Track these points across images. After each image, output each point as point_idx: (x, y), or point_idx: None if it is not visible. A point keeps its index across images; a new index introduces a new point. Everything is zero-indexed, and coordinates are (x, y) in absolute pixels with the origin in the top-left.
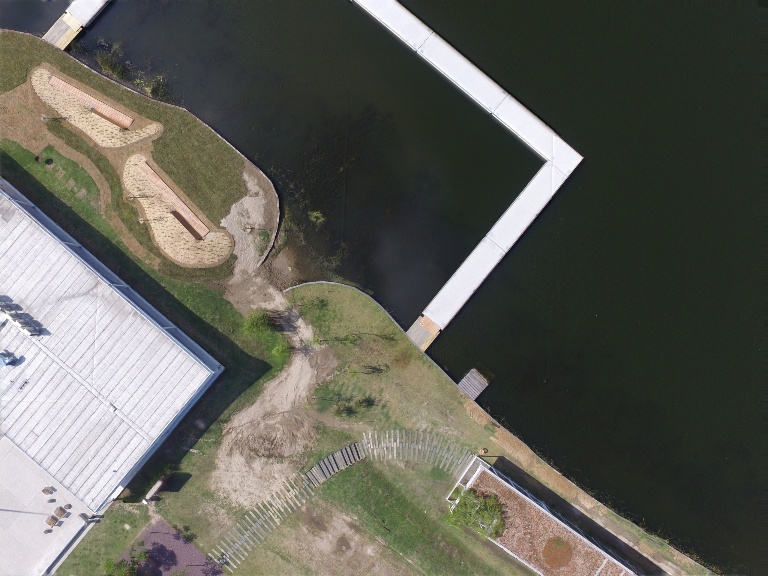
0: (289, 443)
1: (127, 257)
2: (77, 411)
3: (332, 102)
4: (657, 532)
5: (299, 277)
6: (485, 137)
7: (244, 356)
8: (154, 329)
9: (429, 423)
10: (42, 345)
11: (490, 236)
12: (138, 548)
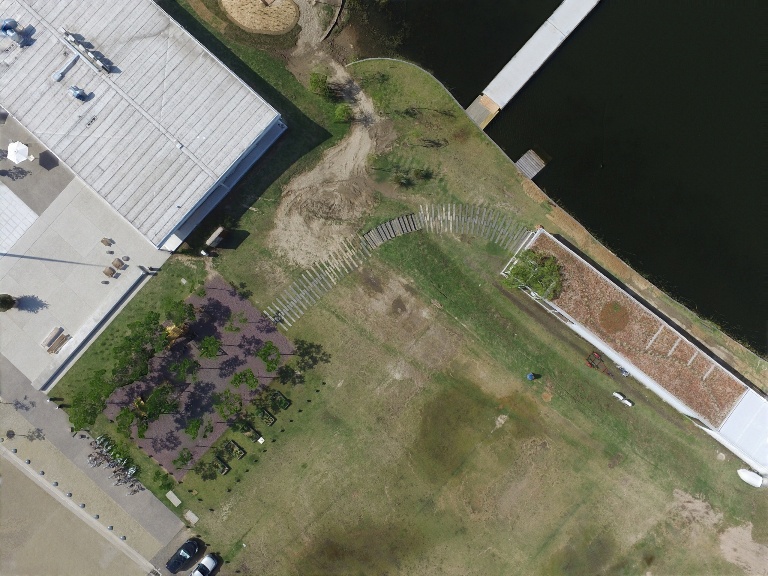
0: (347, 209)
1: (194, 19)
2: (144, 148)
3: None
4: (710, 318)
5: (360, 55)
6: None
7: (306, 119)
8: (223, 70)
9: (486, 198)
10: (112, 82)
11: (551, 20)
12: (194, 303)
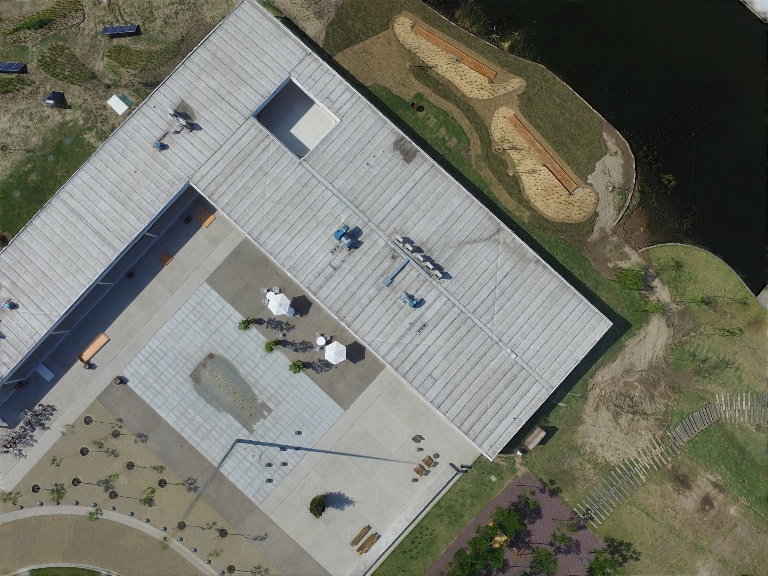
0: (648, 401)
1: (499, 208)
2: (476, 356)
3: (683, 68)
4: None
5: (651, 238)
6: None
7: (612, 312)
8: (556, 278)
9: None
10: (443, 288)
11: None
12: (504, 500)
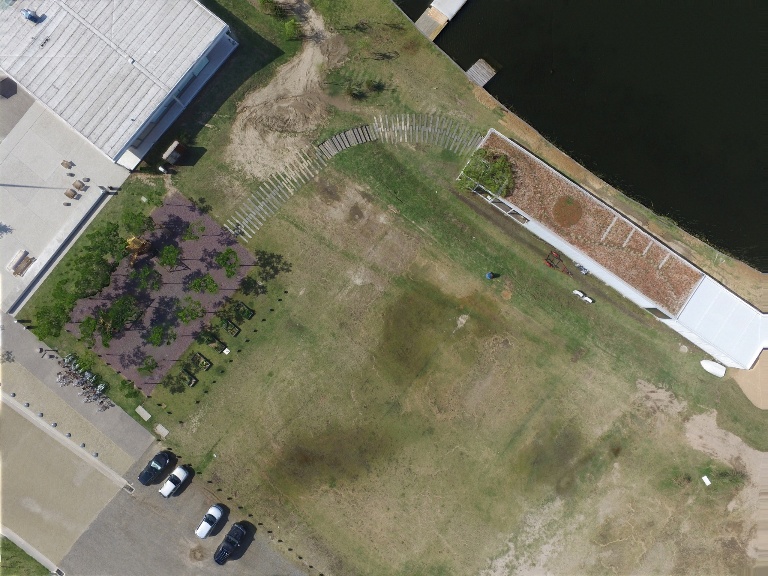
0: (302, 123)
1: None
2: (96, 65)
3: None
4: (666, 214)
5: None
6: None
7: (257, 37)
8: None
9: (438, 107)
10: (63, 3)
11: None
12: (155, 220)
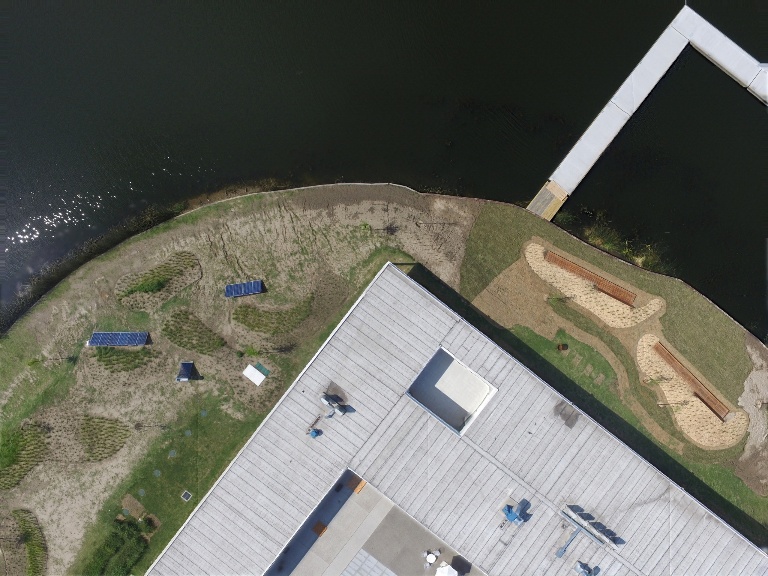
0: None
1: (653, 444)
2: None
3: None
4: None
5: None
6: None
7: None
8: (729, 532)
9: None
10: (617, 554)
11: None
12: None
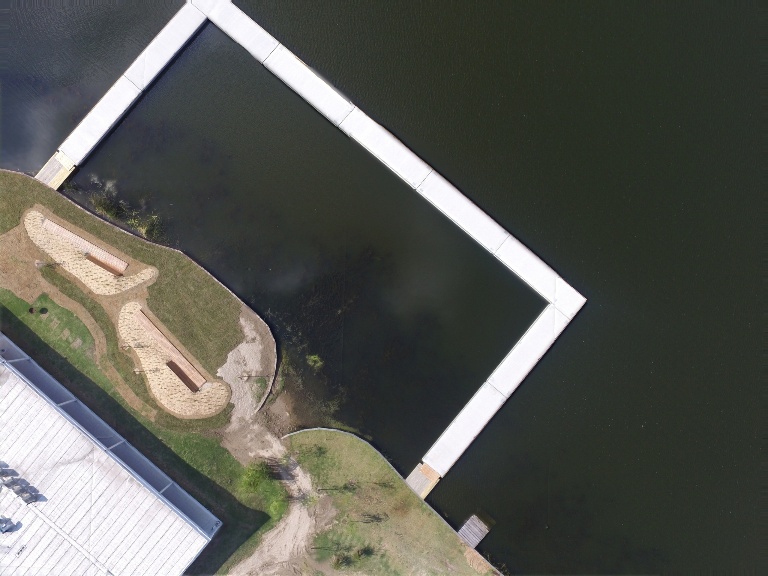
0: None
1: (123, 409)
2: None
3: (330, 242)
4: None
5: (297, 422)
6: (486, 278)
7: (242, 509)
8: (150, 495)
9: (429, 572)
10: (39, 511)
11: (491, 381)
12: None
